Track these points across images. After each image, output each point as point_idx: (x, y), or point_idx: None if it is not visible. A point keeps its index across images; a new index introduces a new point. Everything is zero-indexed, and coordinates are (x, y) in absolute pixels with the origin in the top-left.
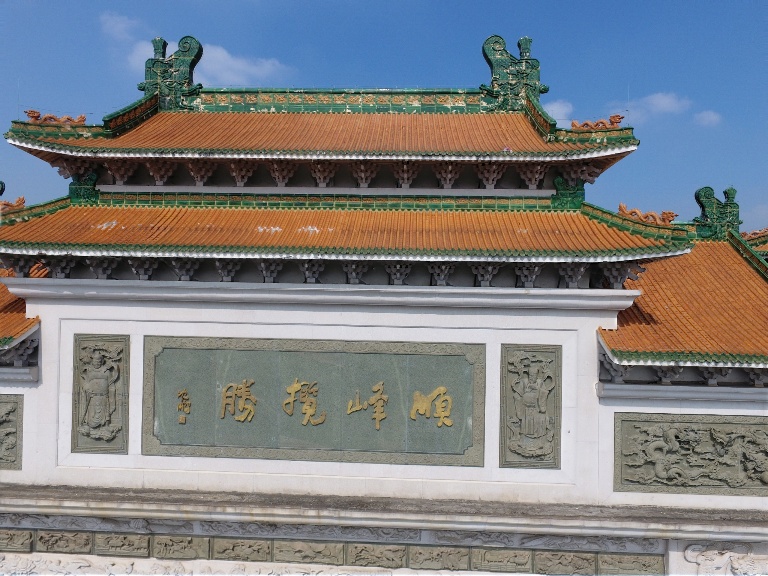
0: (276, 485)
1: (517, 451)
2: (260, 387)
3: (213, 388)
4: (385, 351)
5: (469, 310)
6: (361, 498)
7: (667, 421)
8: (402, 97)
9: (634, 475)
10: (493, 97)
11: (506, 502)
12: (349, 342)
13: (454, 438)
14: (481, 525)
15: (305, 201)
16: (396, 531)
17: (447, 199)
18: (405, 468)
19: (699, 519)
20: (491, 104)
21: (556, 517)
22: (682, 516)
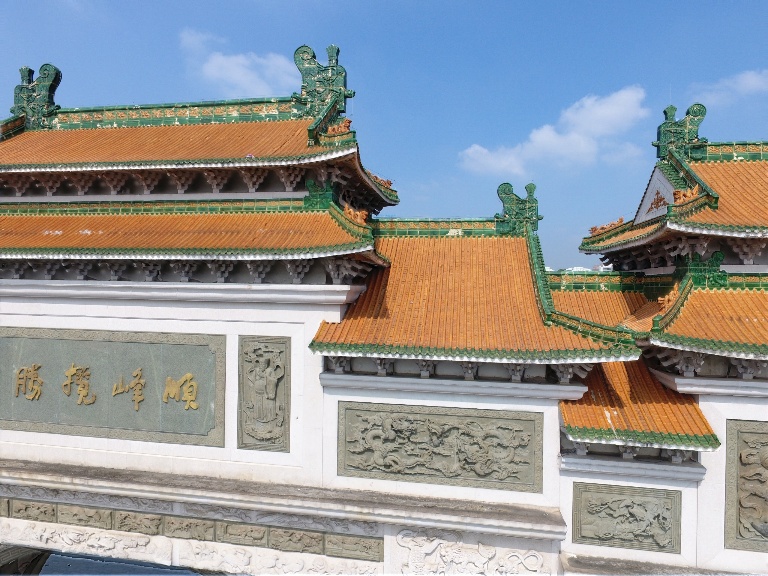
0: (57, 456)
1: (251, 434)
2: (45, 370)
3: (10, 370)
4: (142, 340)
5: (210, 304)
6: (121, 470)
7: (386, 411)
8: (223, 108)
9: (355, 461)
10: (302, 104)
11: (241, 480)
12: (114, 332)
13: (199, 420)
14: (205, 499)
15: (98, 207)
16: (152, 502)
17: (213, 203)
18: (159, 446)
19: (399, 505)
20: (301, 111)
21: (266, 495)
22: (388, 501)
